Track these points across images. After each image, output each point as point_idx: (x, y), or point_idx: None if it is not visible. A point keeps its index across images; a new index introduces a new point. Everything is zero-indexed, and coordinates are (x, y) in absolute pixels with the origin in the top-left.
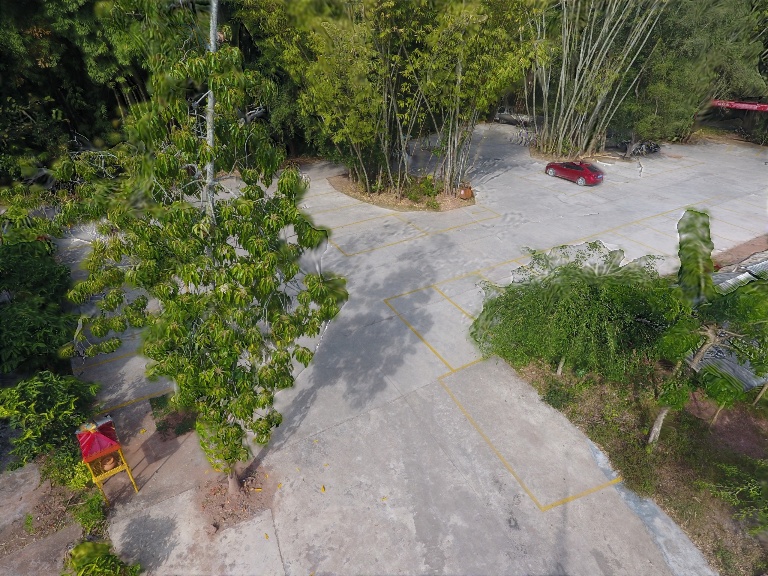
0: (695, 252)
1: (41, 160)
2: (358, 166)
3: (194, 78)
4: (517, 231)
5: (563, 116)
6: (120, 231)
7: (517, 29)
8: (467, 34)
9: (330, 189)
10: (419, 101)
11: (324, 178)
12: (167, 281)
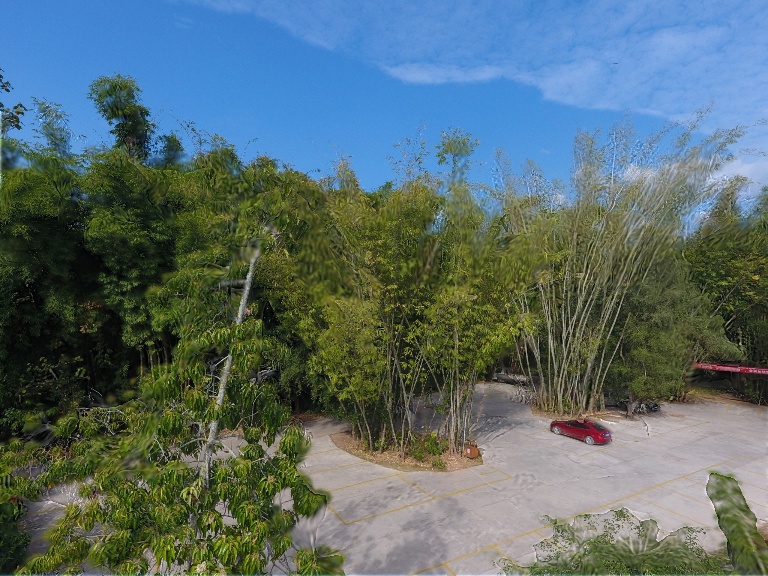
0: (737, 524)
1: (48, 415)
2: (361, 423)
3: (217, 344)
4: (532, 495)
5: (558, 377)
6: (102, 493)
7: (504, 305)
8: (461, 309)
9: (332, 446)
10: (421, 363)
11: (326, 435)
12: (137, 557)
